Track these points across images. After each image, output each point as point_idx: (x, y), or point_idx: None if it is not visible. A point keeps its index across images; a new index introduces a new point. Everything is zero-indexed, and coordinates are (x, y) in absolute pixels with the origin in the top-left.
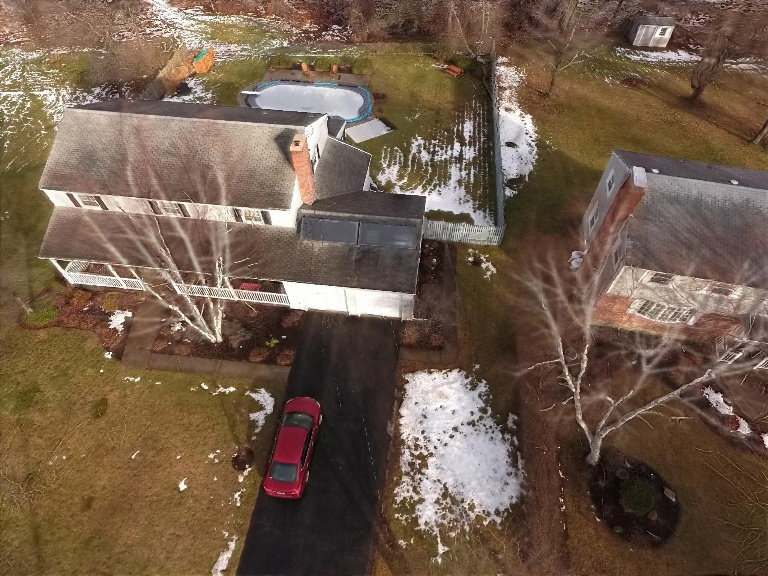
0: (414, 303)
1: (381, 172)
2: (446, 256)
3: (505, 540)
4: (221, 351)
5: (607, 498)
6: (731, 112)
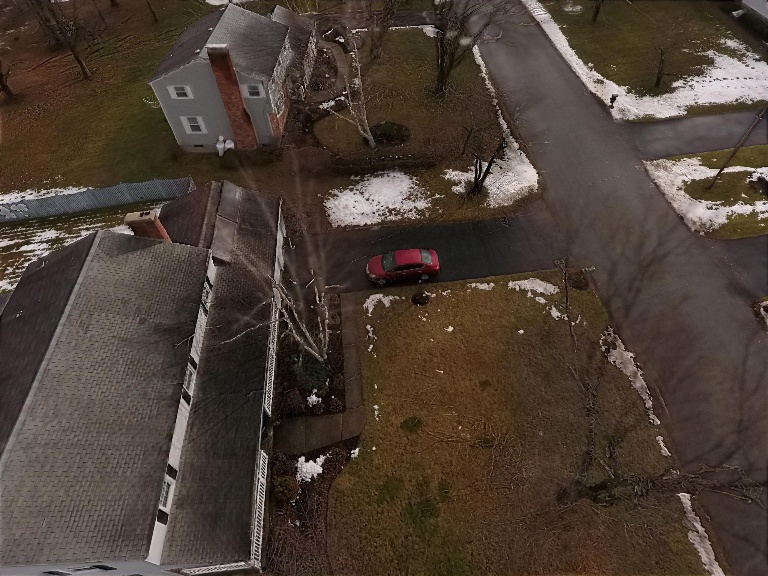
0: None
1: None
2: None
3: (424, 175)
4: (334, 349)
5: (391, 141)
6: (37, 84)
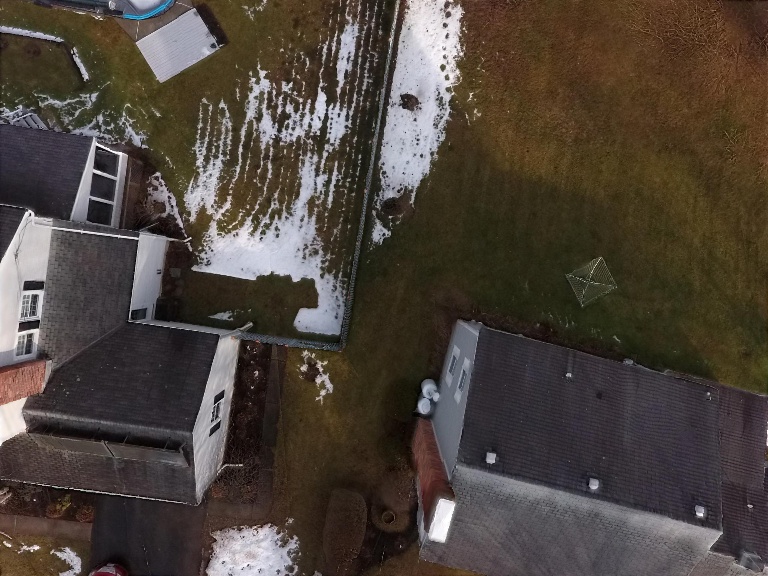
0: (210, 482)
1: (191, 183)
2: (272, 364)
3: None
4: (14, 505)
5: None
6: None
